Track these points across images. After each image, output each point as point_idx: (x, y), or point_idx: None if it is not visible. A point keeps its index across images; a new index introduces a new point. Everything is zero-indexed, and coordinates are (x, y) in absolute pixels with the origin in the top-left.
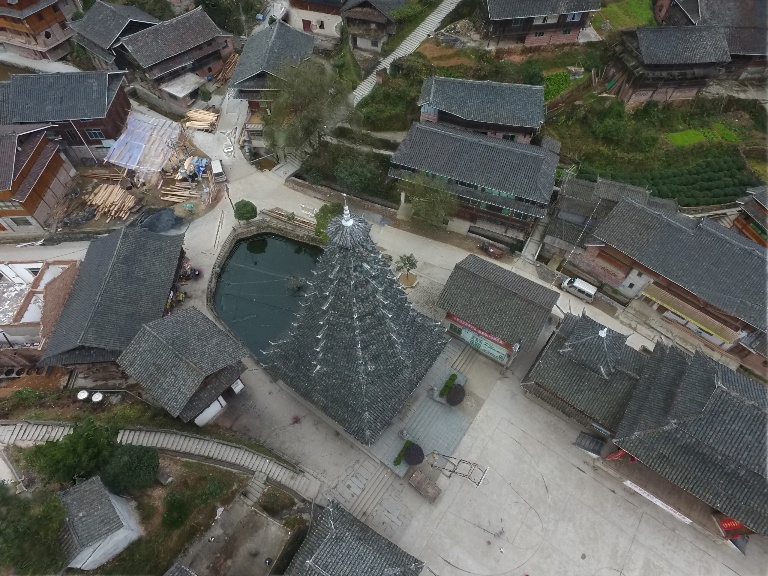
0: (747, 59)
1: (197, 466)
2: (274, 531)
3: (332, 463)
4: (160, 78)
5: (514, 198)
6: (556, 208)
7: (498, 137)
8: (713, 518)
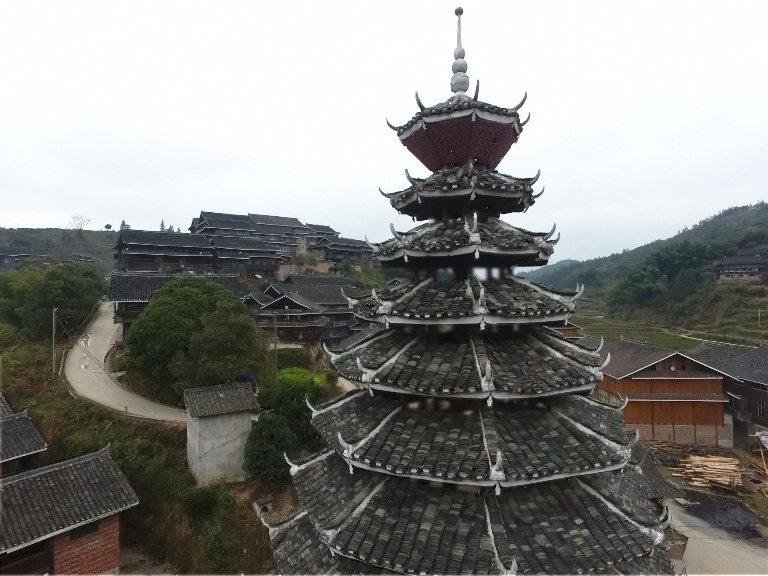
0: None
1: None
2: None
3: None
4: None
5: None
6: None
7: None
8: None
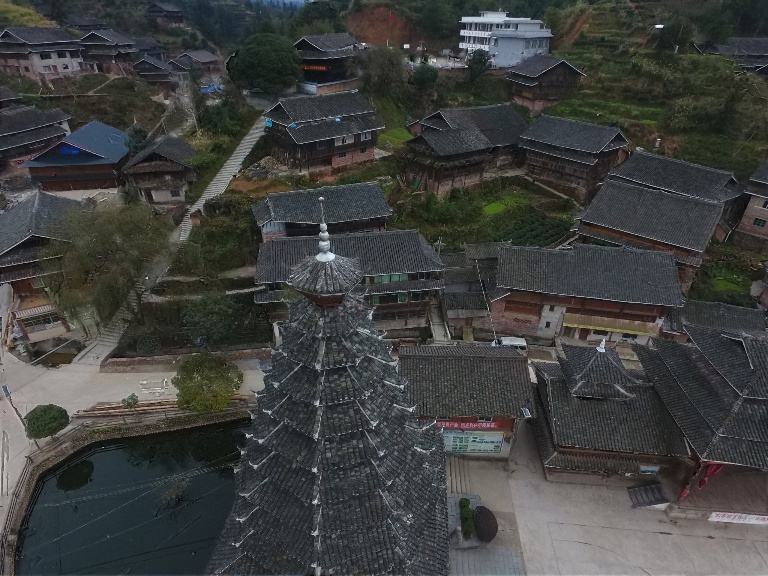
0: (496, 150)
1: None
2: None
3: None
4: None
5: (407, 279)
6: None
7: None
8: None
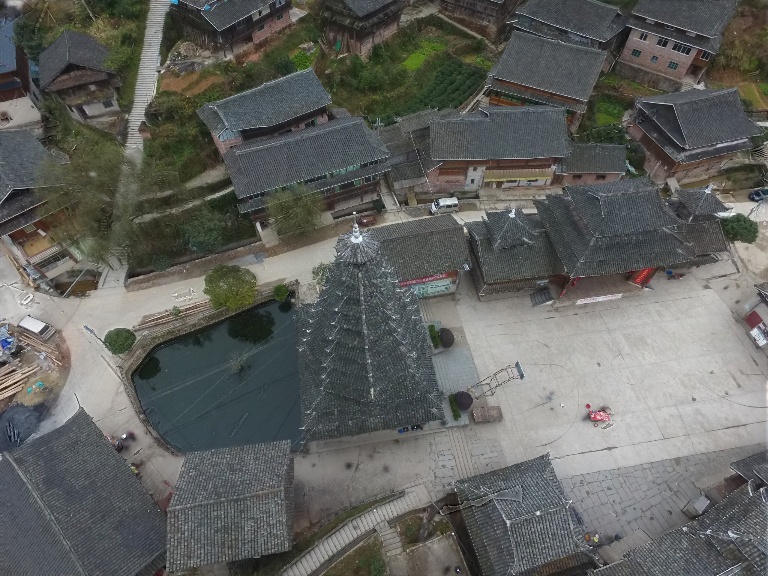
0: None
1: (334, 571)
2: (438, 547)
3: (416, 464)
4: None
5: (359, 167)
6: None
7: (301, 128)
8: (629, 282)
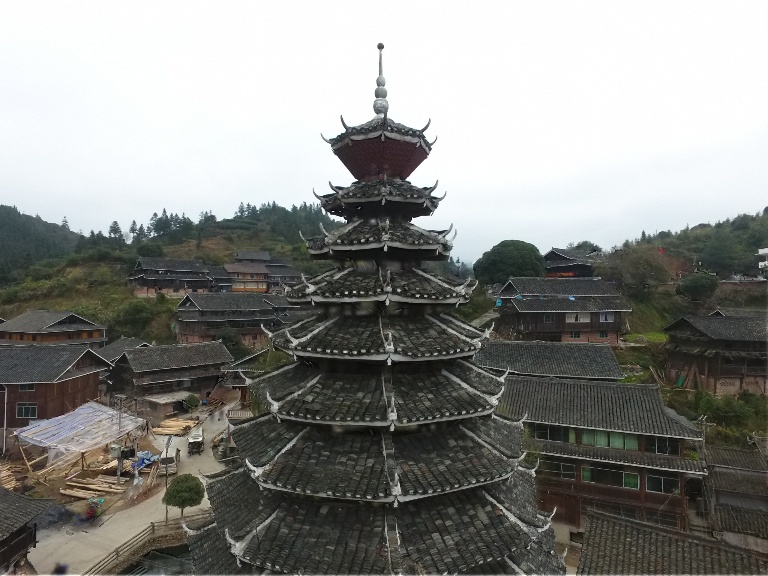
0: None
1: None
2: None
3: None
4: (148, 387)
5: (636, 448)
6: (707, 499)
7: None
8: None
